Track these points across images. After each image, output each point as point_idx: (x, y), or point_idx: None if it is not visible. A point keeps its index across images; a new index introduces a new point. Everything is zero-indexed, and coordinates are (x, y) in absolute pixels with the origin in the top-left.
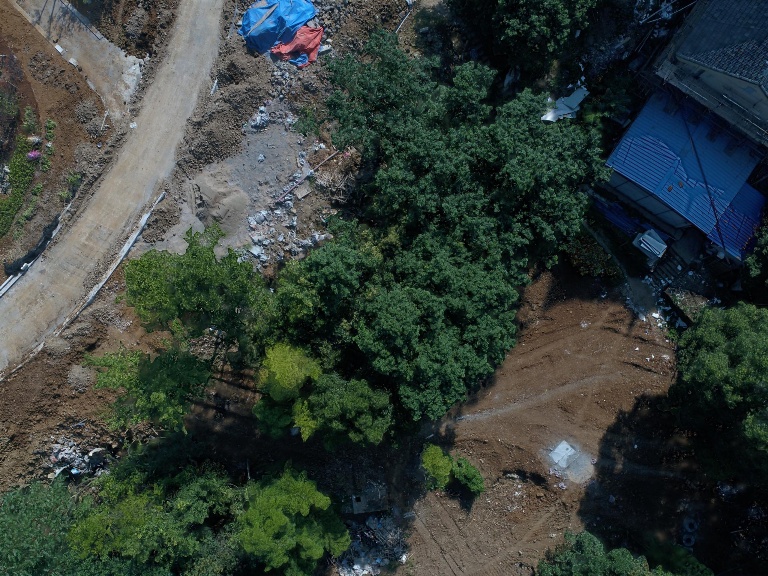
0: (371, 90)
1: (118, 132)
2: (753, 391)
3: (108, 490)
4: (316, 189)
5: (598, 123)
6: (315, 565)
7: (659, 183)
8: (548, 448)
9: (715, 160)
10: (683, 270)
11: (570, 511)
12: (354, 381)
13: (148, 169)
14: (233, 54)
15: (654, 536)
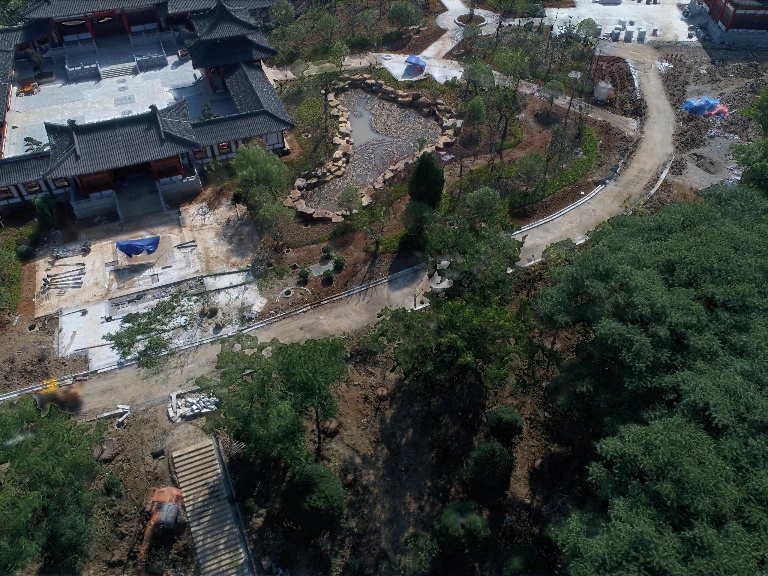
0: None
1: None
2: None
3: None
4: None
5: None
6: None
7: None
8: None
9: None
10: None
11: None
12: None
13: (660, 150)
14: None
15: None
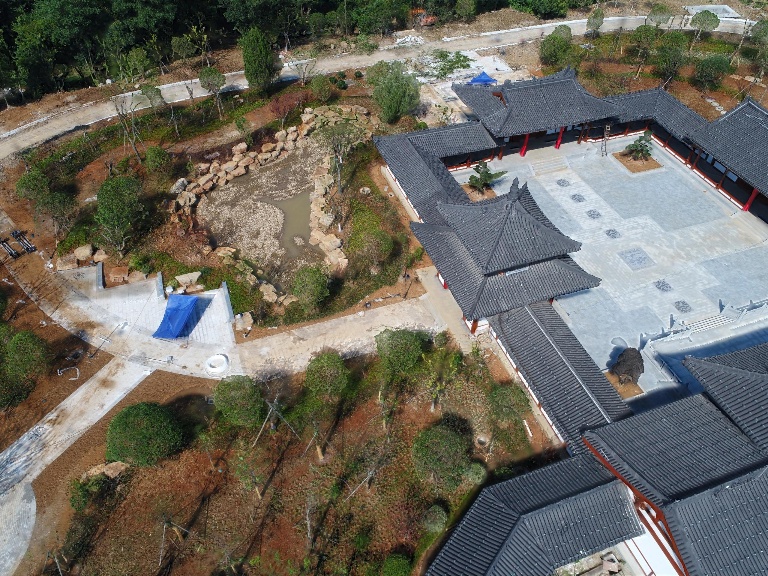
0: None
1: None
2: None
3: None
4: None
5: None
6: None
7: None
8: None
9: None
10: None
11: None
12: None
13: None
14: None
15: None
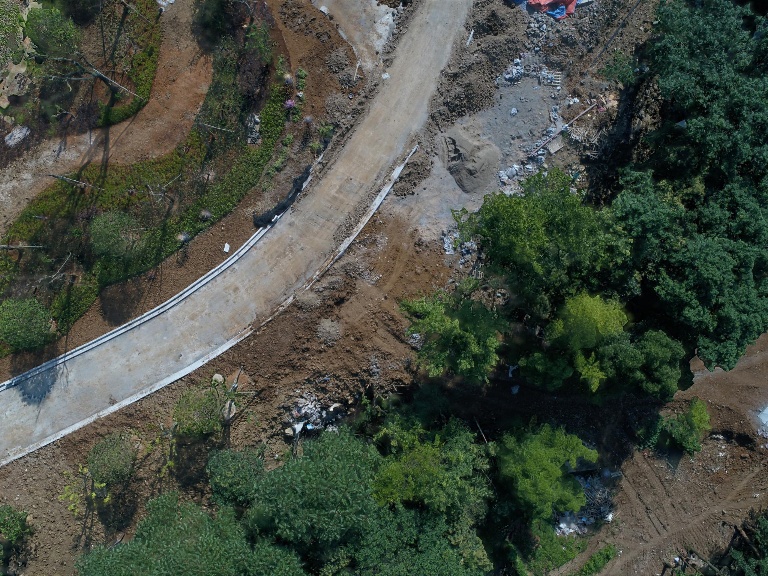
0: (703, 35)
1: (372, 83)
2: None
3: (400, 439)
4: (568, 144)
5: None
6: None
7: None
8: (757, 409)
9: None
10: None
11: None
12: (653, 332)
13: (400, 121)
14: (492, 4)
15: None
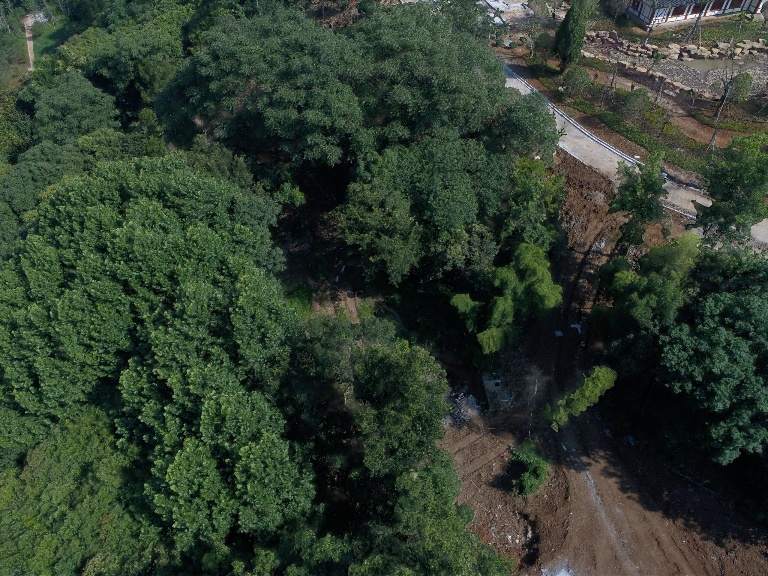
0: None
1: None
2: None
3: None
4: None
5: None
6: (469, 323)
7: None
8: (571, 568)
9: None
10: None
11: None
12: None
13: (760, 231)
14: None
15: None
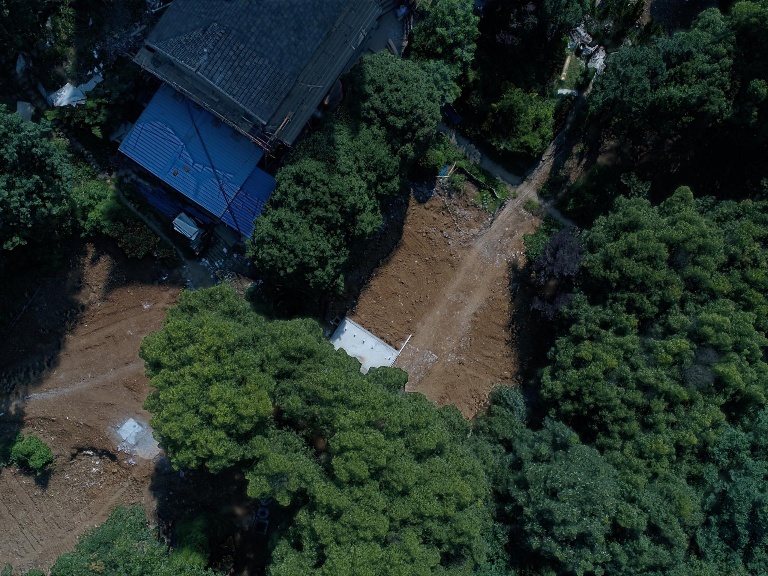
0: None
1: None
2: (160, 366)
3: None
4: None
5: (102, 109)
6: None
7: (164, 168)
8: (115, 425)
9: (222, 145)
10: (228, 252)
11: (142, 486)
12: None
13: None
14: None
15: (230, 509)
